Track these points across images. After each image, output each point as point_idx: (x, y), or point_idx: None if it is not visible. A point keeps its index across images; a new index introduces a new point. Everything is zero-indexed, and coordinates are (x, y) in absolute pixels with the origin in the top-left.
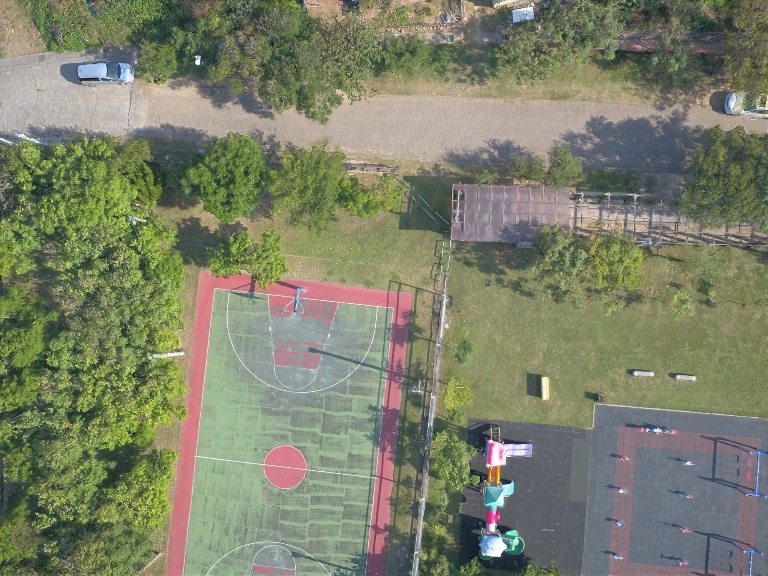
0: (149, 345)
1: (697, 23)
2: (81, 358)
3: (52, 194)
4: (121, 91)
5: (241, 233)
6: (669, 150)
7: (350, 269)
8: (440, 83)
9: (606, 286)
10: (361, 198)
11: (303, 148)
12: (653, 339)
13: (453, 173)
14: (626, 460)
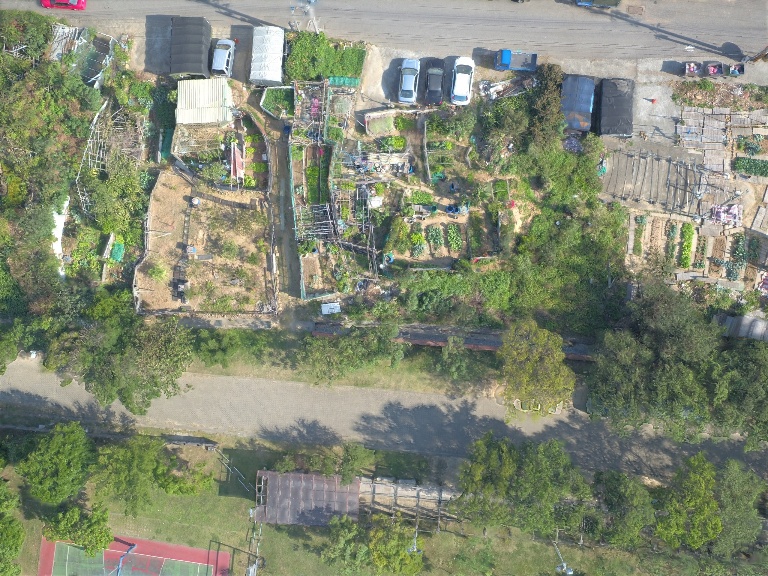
0: None
1: (484, 324)
2: None
3: None
4: None
5: (80, 492)
6: (457, 437)
7: (175, 529)
8: (257, 366)
9: None
10: (172, 487)
11: (135, 419)
12: None
13: (267, 448)
14: None
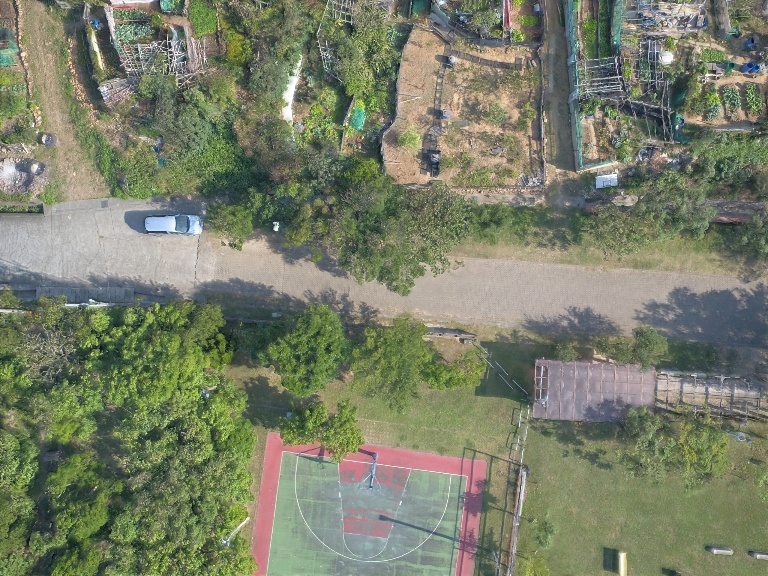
0: (219, 519)
1: None
2: (148, 534)
3: (121, 362)
4: (188, 242)
5: (311, 394)
6: (753, 325)
7: (424, 435)
8: (520, 247)
9: None
10: (444, 377)
11: (377, 309)
12: (733, 516)
13: (532, 340)
14: None
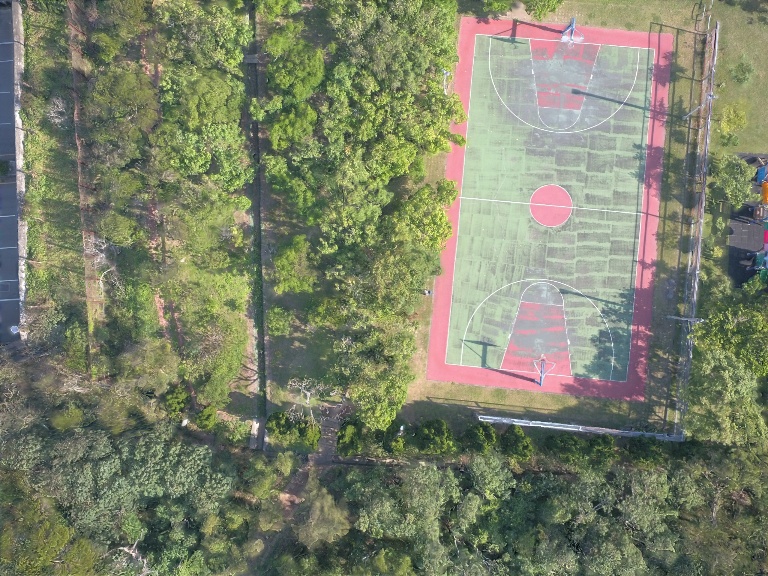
0: (428, 74)
1: None
2: (364, 85)
3: None
4: None
5: None
6: None
7: (611, 12)
8: None
9: None
10: None
11: None
12: None
13: None
14: None
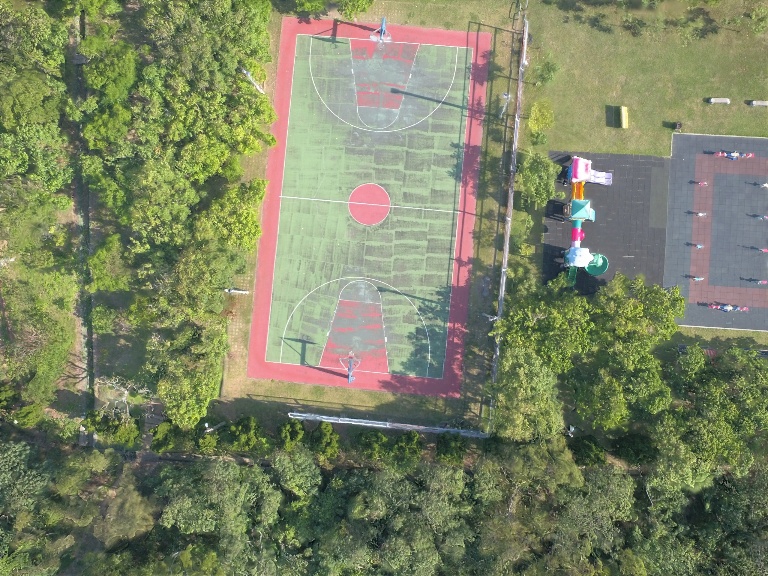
0: (239, 74)
1: None
2: (173, 85)
3: None
4: None
5: None
6: None
7: (430, 11)
8: None
9: (682, 18)
10: None
11: None
12: (729, 68)
13: None
14: (705, 184)
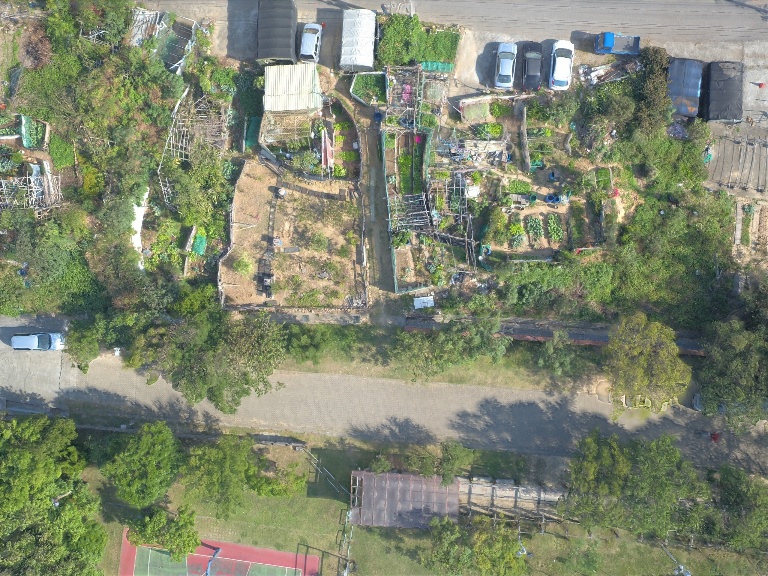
0: None
1: (585, 318)
2: None
3: None
4: (53, 356)
5: None
6: (557, 435)
7: (262, 532)
8: (346, 362)
9: None
10: (265, 489)
11: (219, 418)
12: None
13: (357, 447)
14: None
